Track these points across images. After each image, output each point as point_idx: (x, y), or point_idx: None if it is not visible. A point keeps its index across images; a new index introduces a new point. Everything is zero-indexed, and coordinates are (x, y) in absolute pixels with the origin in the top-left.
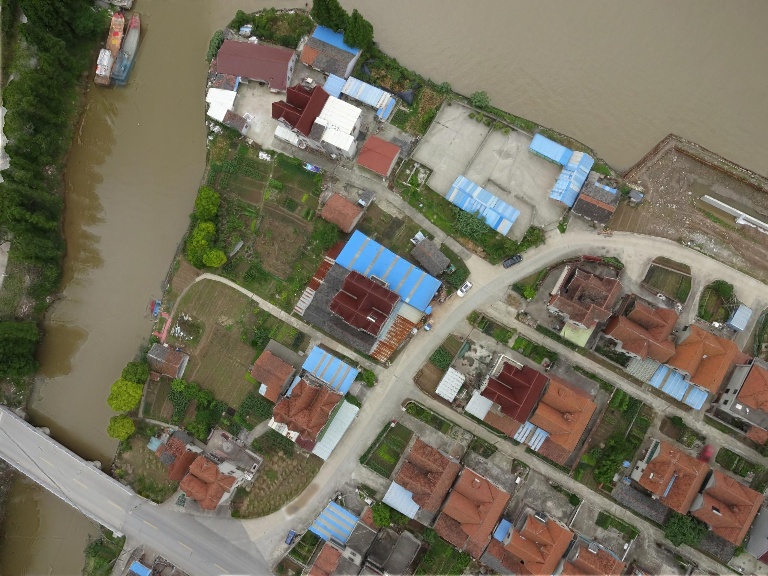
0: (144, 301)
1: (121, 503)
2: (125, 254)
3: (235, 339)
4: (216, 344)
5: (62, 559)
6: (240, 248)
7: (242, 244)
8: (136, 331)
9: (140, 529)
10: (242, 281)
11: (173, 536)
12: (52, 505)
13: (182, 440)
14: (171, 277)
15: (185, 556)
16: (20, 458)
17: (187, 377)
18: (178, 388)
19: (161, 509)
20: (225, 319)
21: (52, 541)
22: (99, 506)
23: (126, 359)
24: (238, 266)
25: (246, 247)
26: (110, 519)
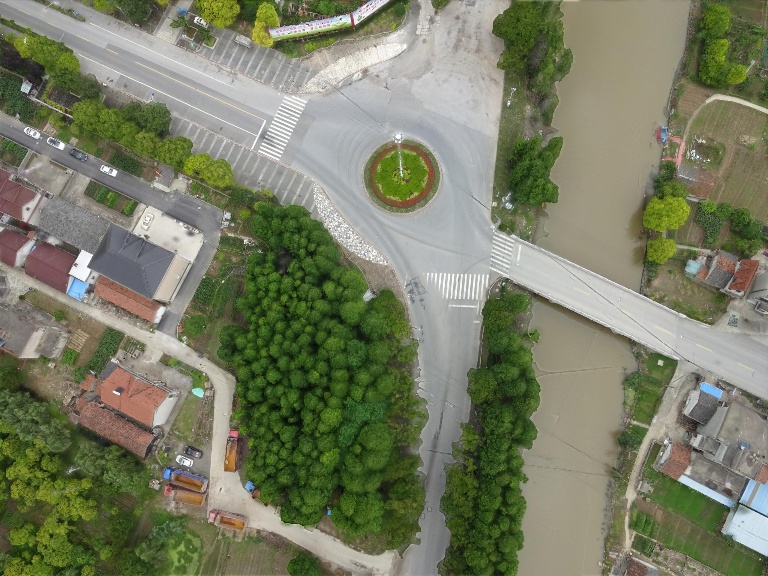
0: (644, 129)
1: (670, 328)
2: (580, 96)
3: (760, 157)
4: (739, 164)
5: (577, 402)
6: (751, 66)
7: (754, 62)
8: (634, 162)
9: (693, 353)
10: (757, 100)
11: (730, 357)
12: (544, 352)
13: (729, 258)
14: (676, 101)
15: (746, 377)
16: (550, 290)
17: (713, 199)
18: (710, 209)
19: (713, 331)
20: (747, 138)
21: (551, 388)
22: (646, 332)
23: (605, 199)
24: (750, 85)
25: (758, 65)
26: (660, 345)
